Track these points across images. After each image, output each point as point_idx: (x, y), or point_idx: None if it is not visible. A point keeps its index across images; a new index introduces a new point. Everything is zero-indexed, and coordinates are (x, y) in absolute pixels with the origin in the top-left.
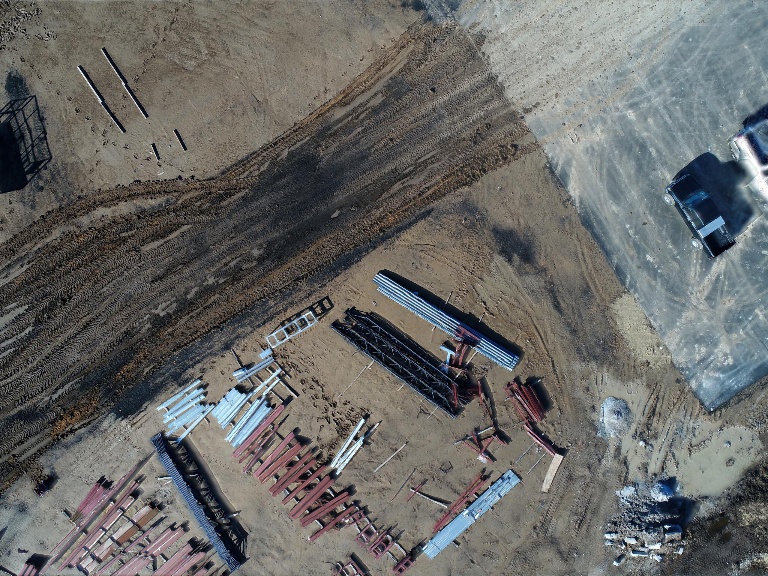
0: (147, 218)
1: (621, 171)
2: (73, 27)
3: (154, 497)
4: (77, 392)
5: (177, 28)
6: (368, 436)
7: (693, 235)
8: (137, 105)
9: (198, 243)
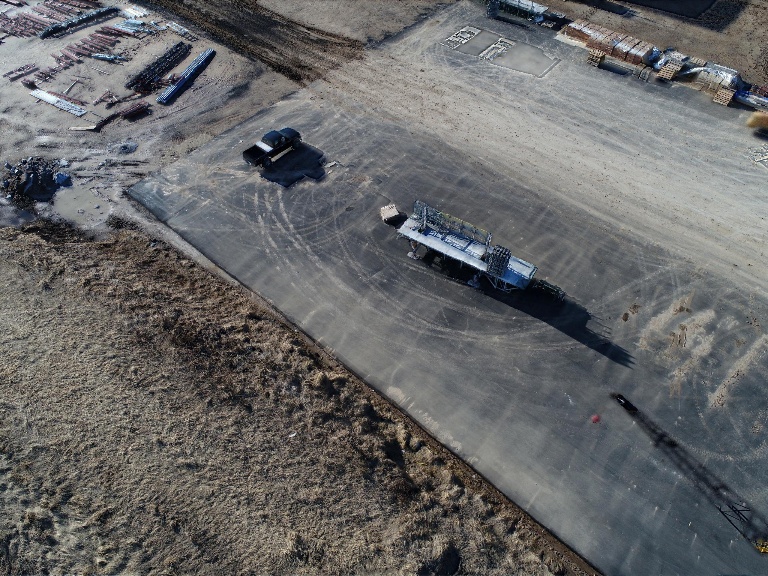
0: None
1: (298, 119)
2: None
3: (84, 13)
4: None
5: None
6: (114, 63)
7: None
8: None
9: None
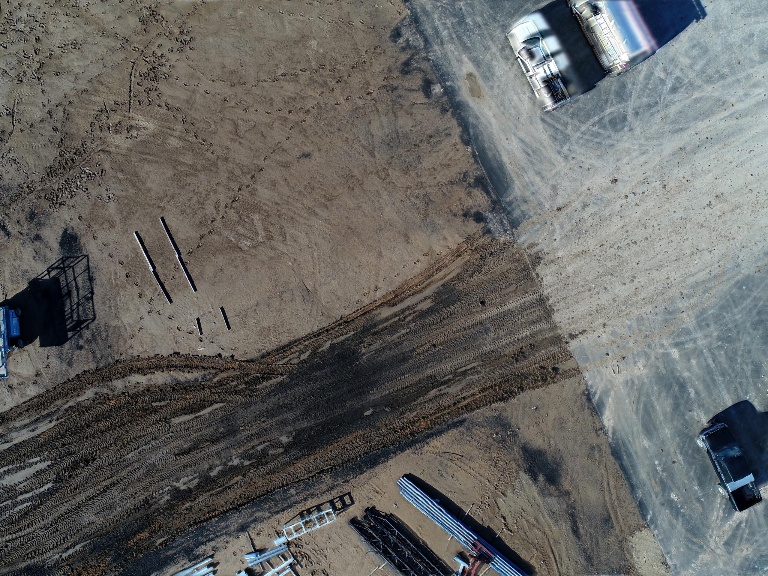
0: (181, 391)
1: (658, 408)
2: (135, 192)
3: None
4: (87, 553)
5: (238, 207)
6: None
7: (721, 483)
8: (187, 278)
9: (229, 422)
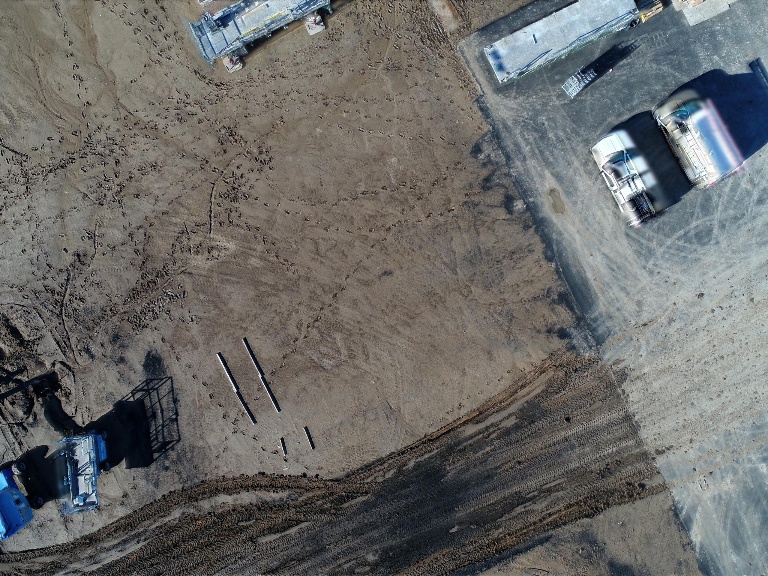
0: (267, 511)
1: (745, 522)
2: (217, 314)
3: None
4: None
5: (320, 326)
6: None
7: None
8: (271, 398)
9: (314, 541)
